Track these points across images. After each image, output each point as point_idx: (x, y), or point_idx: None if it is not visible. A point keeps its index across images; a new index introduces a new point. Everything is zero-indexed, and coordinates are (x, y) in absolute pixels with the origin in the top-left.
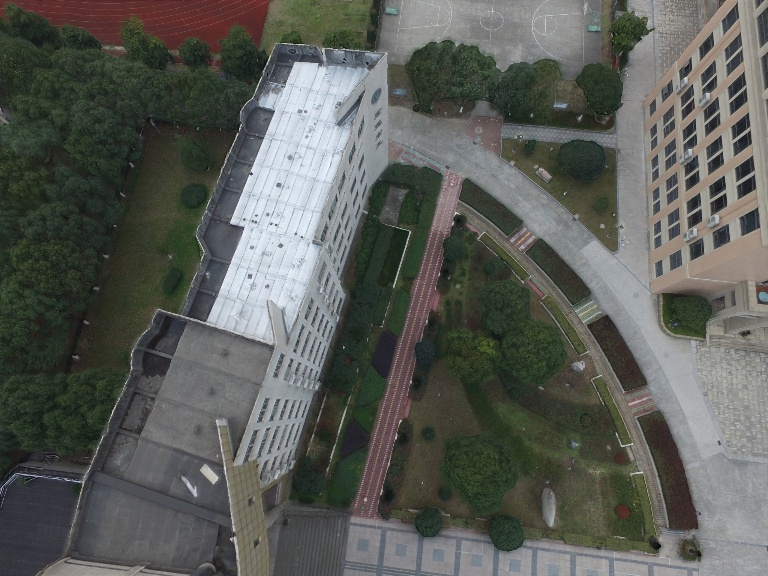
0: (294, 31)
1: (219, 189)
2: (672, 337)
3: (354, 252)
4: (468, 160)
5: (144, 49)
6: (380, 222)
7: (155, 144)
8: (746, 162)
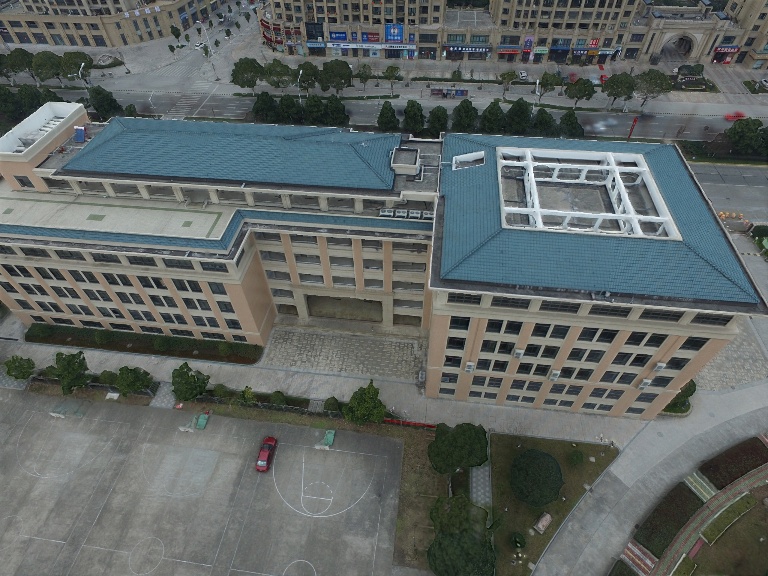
0: None
1: None
2: None
3: None
4: None
5: None
6: None
7: None
8: (631, 337)
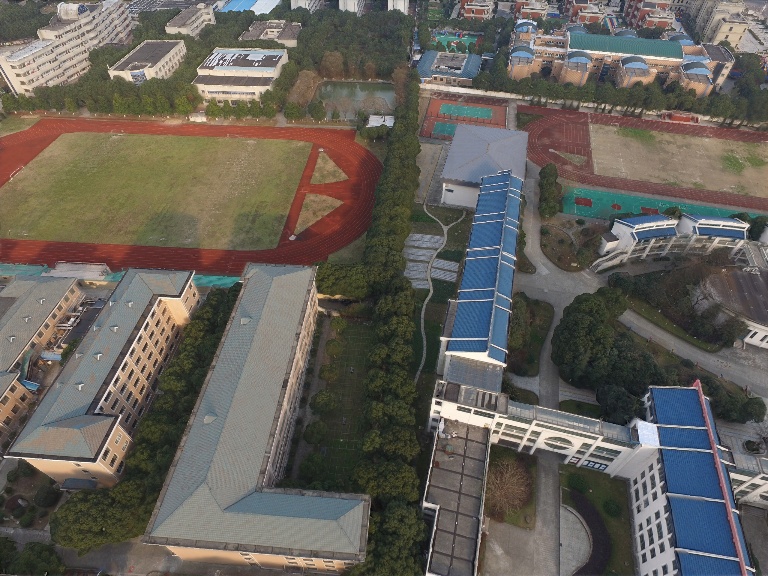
0: (18, 96)
1: None
2: None
3: None
4: None
5: None
6: None
7: None
8: None
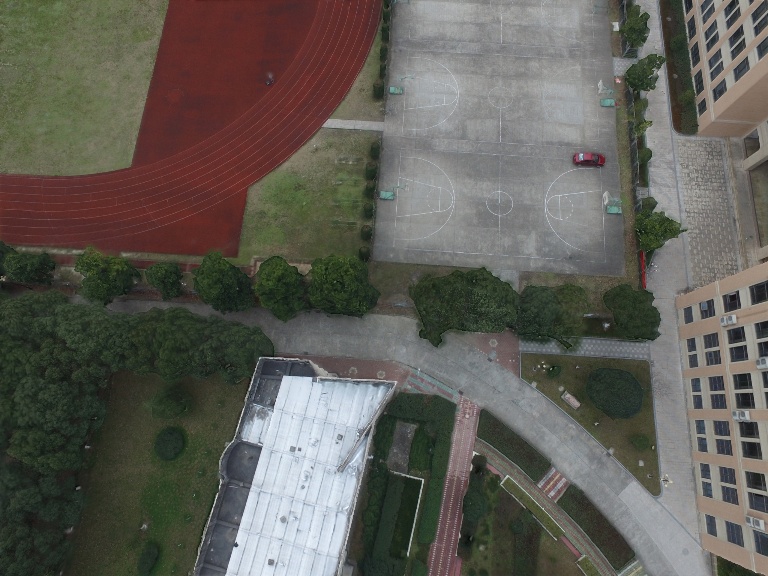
0: (279, 263)
1: (197, 573)
2: None
3: (360, 510)
4: (484, 382)
5: (104, 280)
6: (388, 469)
7: (123, 376)
8: None
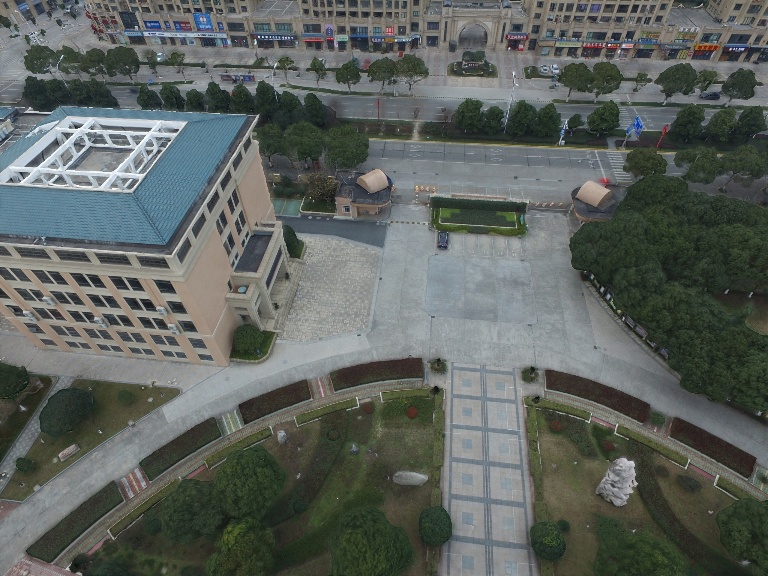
0: None
1: None
2: (270, 356)
3: None
4: (3, 547)
5: None
6: None
7: None
8: (113, 281)
